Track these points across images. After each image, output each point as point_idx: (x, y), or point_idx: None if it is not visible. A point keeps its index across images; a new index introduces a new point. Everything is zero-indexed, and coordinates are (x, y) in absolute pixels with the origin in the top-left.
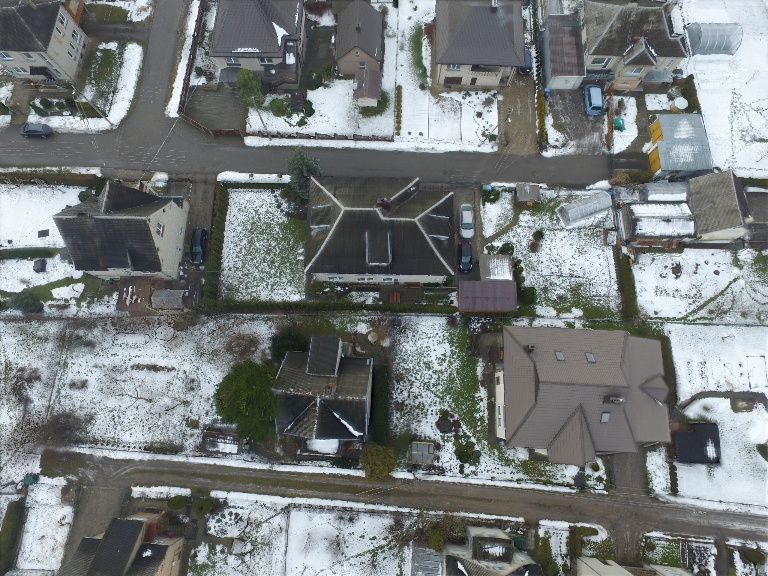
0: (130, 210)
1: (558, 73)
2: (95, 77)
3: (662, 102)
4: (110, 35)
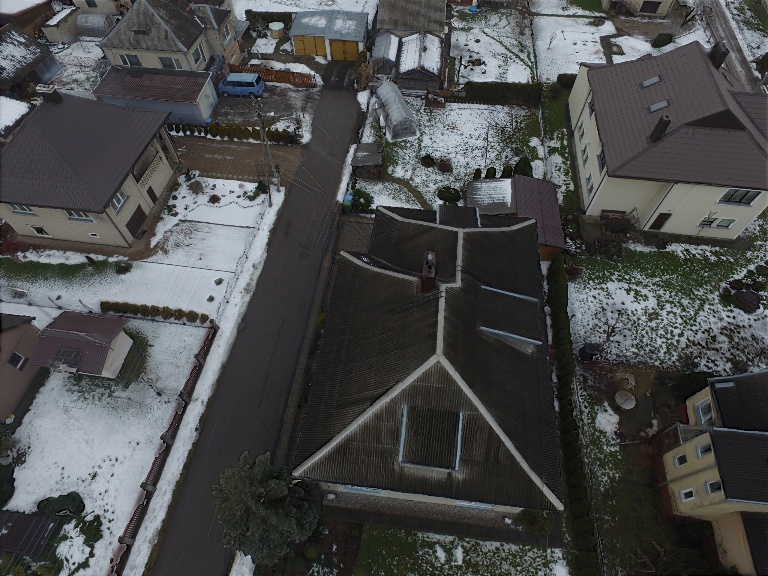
0: None
1: (193, 95)
2: None
3: (266, 43)
4: None
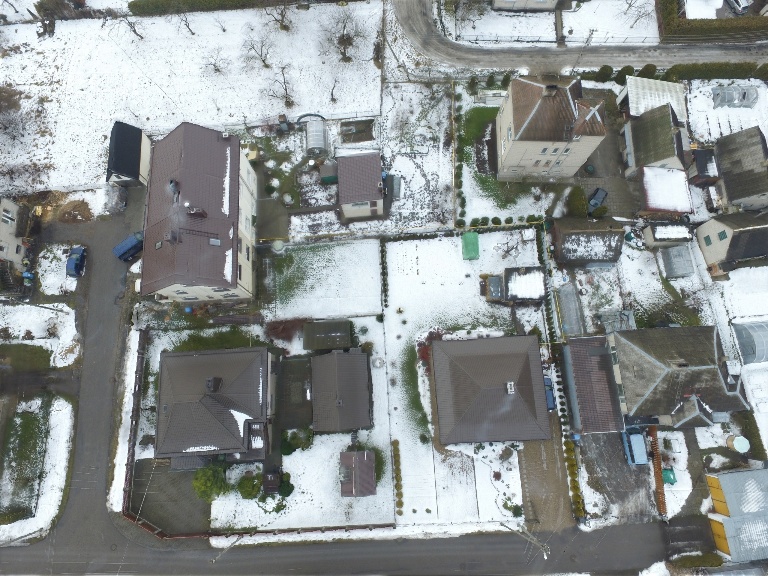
0: None
1: (590, 427)
2: (15, 456)
3: (716, 435)
4: (30, 390)
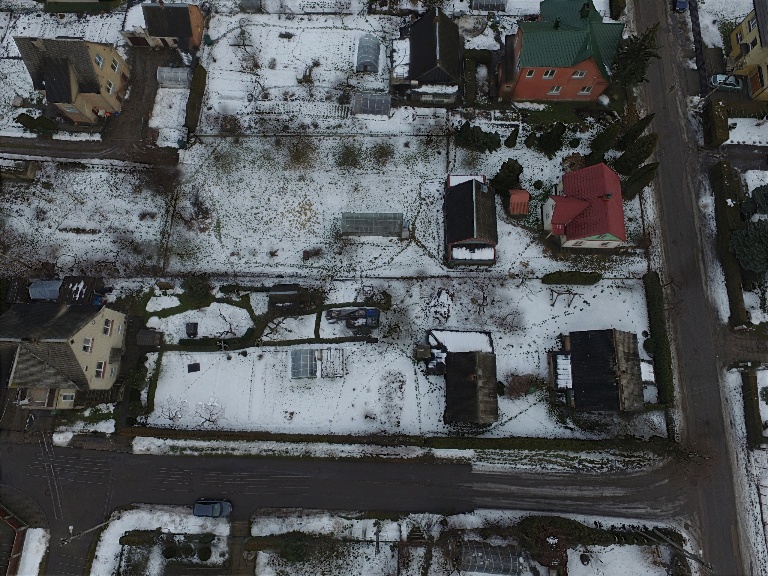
0: (5, 357)
1: None
2: None
3: None
4: None
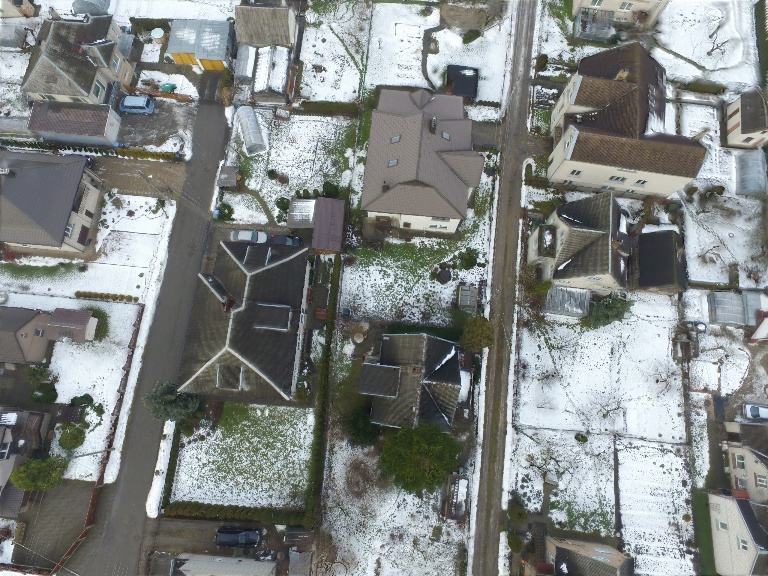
0: None
1: (101, 130)
2: None
3: (152, 49)
4: None
